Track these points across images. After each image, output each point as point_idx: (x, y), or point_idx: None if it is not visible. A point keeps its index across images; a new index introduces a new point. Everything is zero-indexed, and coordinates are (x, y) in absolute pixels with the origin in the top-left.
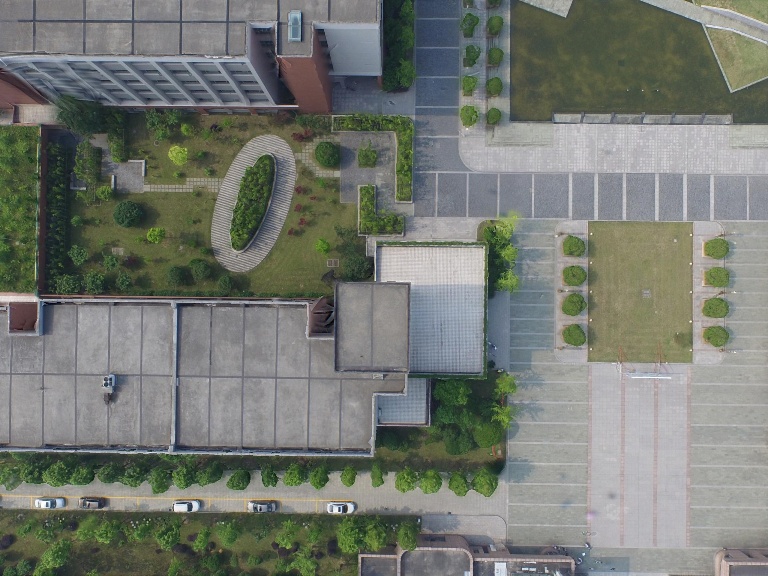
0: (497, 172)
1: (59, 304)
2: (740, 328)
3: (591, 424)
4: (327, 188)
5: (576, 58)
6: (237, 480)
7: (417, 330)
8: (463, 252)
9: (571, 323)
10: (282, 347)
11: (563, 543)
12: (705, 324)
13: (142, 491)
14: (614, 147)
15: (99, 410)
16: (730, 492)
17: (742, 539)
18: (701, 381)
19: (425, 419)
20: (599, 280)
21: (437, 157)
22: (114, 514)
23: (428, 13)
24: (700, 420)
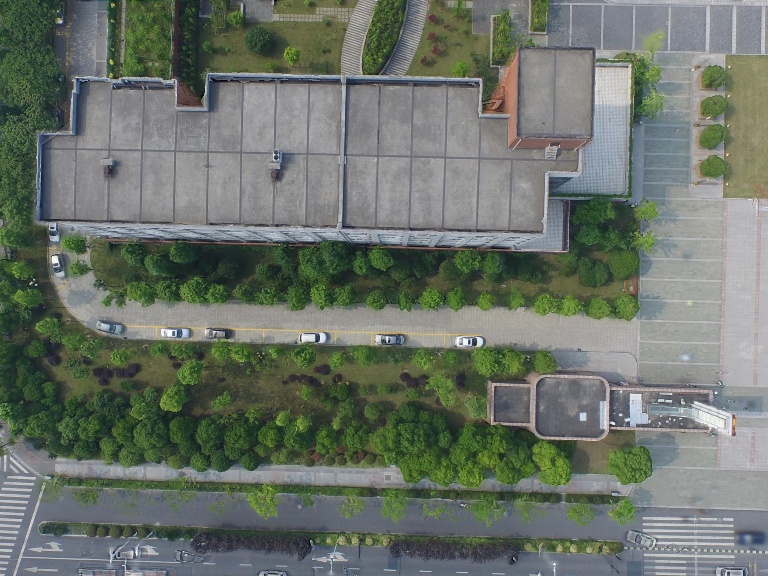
0: (633, 4)
1: (225, 81)
2: None
3: (725, 261)
4: (459, 18)
5: None
6: (378, 295)
7: None
8: (607, 72)
9: None
10: (452, 127)
11: (695, 381)
12: None
13: (268, 323)
14: None
15: (264, 189)
16: None
17: None
18: None
19: (562, 246)
20: (736, 114)
21: None
22: (240, 345)
23: None
24: None
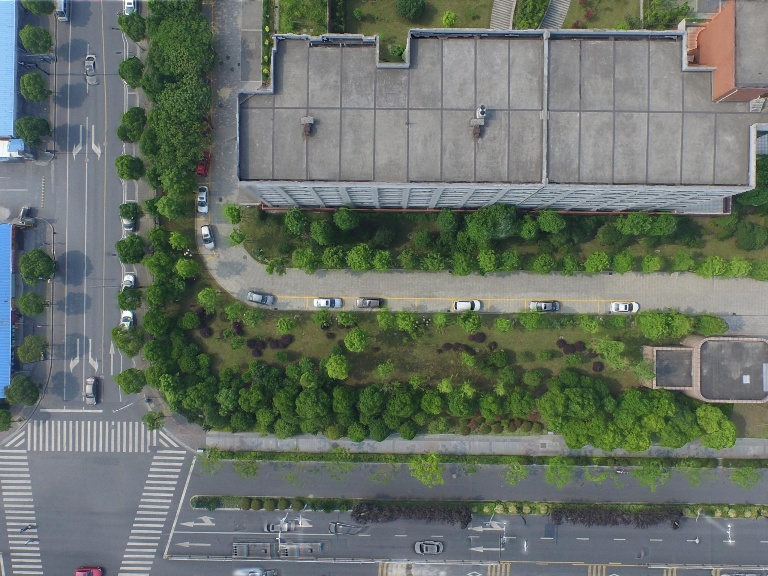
0: None
1: (423, 38)
2: None
3: None
4: None
5: None
6: (549, 258)
7: None
8: None
9: None
10: (654, 81)
11: None
12: None
13: (420, 292)
14: None
15: (466, 146)
16: None
17: None
18: None
19: (722, 209)
20: None
21: None
22: (393, 314)
23: None
24: None
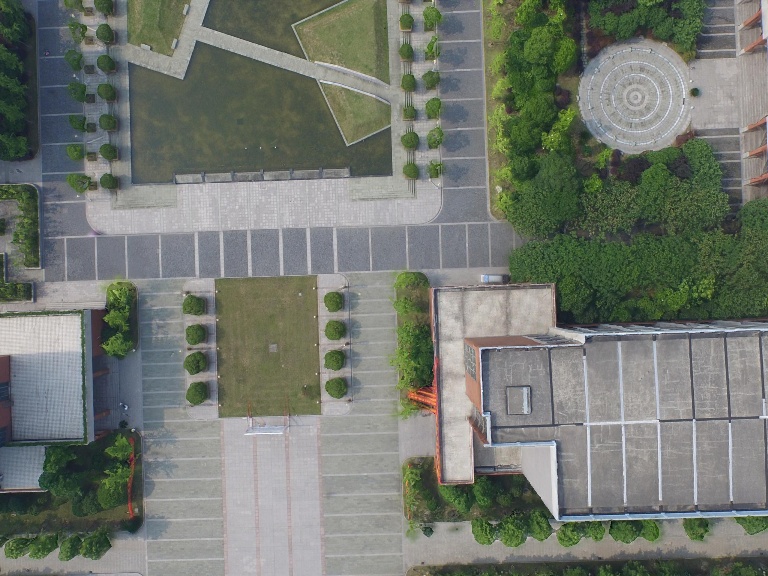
0: (124, 234)
1: None
2: (367, 378)
3: (225, 479)
4: None
5: (196, 119)
6: None
7: (22, 399)
8: (65, 320)
9: (200, 380)
10: None
11: None
12: (332, 375)
13: None
14: (237, 205)
15: None
16: (364, 540)
17: None
18: (331, 432)
19: None
20: (227, 337)
21: (65, 222)
22: None
23: (51, 81)
24: (331, 470)
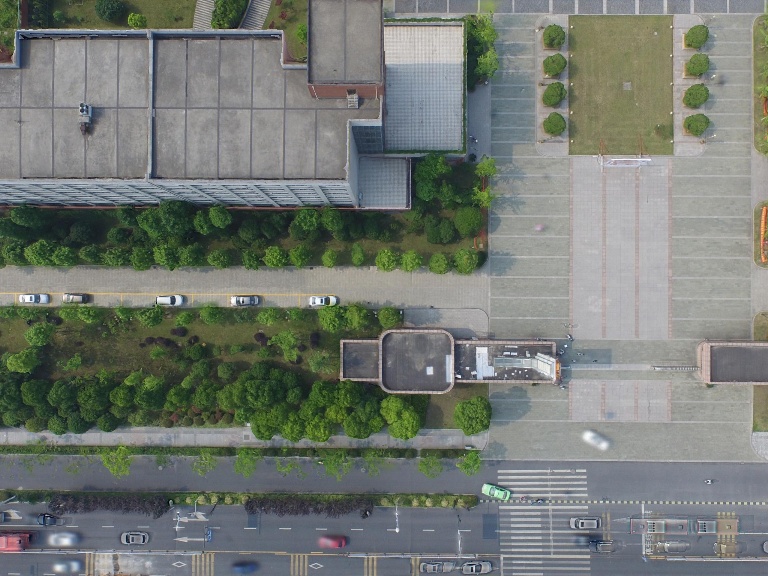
0: None
1: (36, 39)
2: (721, 120)
3: (572, 217)
4: None
5: None
6: (218, 253)
7: (397, 109)
8: (442, 31)
9: None
10: (257, 78)
11: (545, 336)
12: (686, 116)
13: (125, 287)
14: None
15: (76, 143)
16: (712, 283)
17: (724, 330)
18: (682, 173)
19: (406, 204)
20: (580, 73)
21: None
22: (98, 309)
23: None
24: (681, 212)
